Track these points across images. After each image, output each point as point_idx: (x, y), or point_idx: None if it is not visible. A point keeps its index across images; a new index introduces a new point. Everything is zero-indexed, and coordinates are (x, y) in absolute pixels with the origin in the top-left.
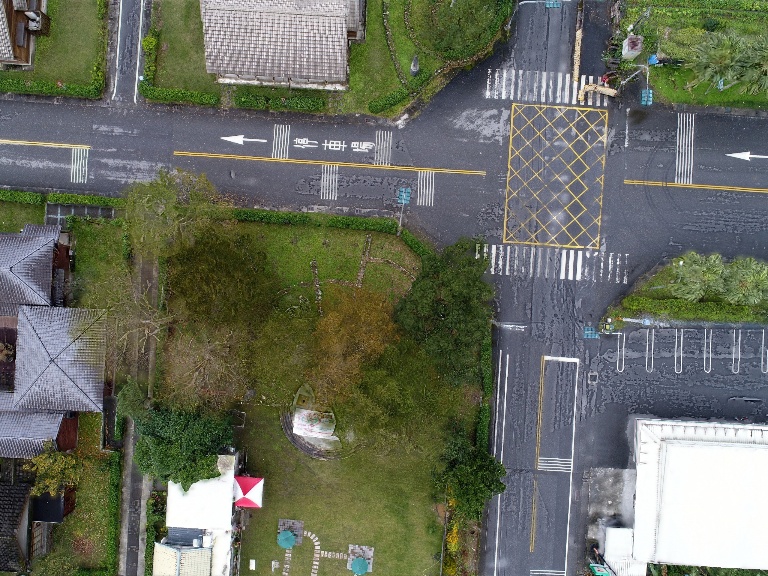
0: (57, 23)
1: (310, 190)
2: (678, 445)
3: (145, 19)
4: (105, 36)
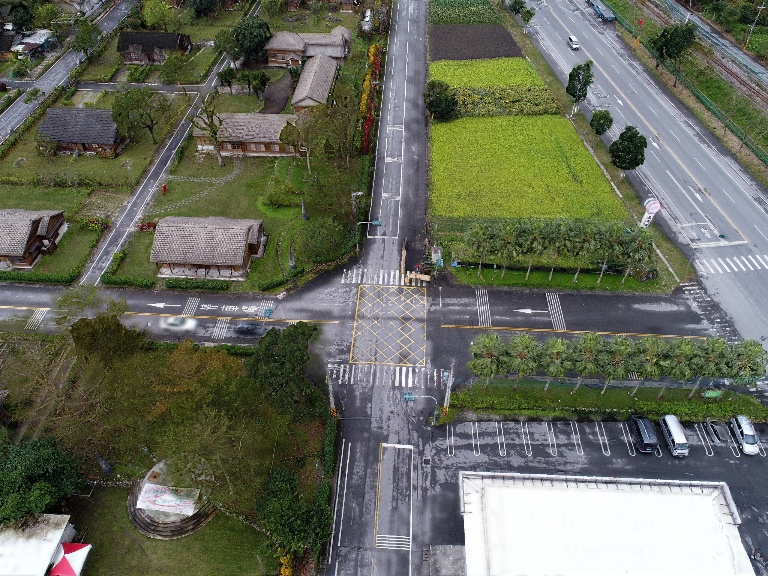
0: (61, 249)
1: (205, 333)
2: (494, 485)
3: (120, 248)
4: (90, 255)
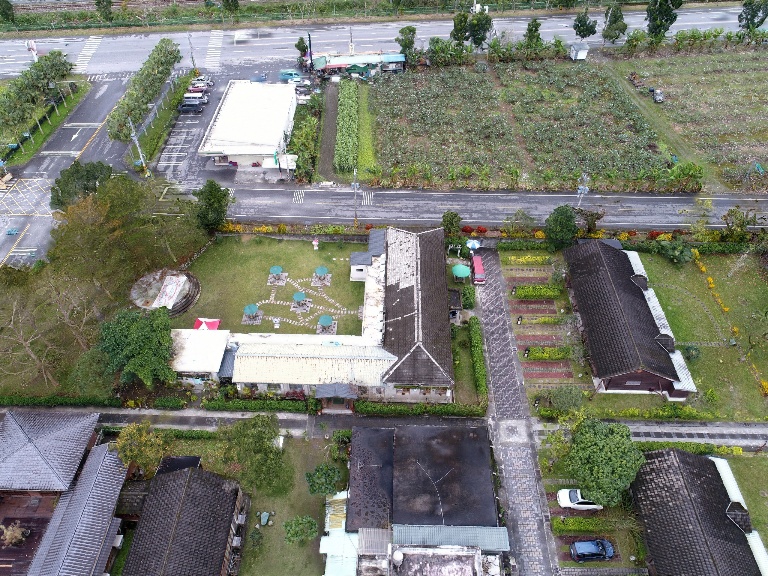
0: None
1: None
2: (212, 136)
3: None
4: None
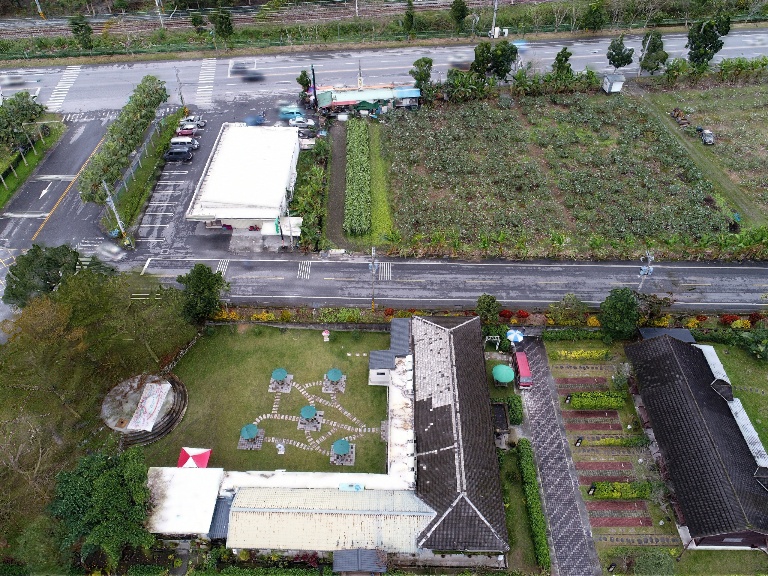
0: None
1: None
2: (202, 197)
3: None
4: None
